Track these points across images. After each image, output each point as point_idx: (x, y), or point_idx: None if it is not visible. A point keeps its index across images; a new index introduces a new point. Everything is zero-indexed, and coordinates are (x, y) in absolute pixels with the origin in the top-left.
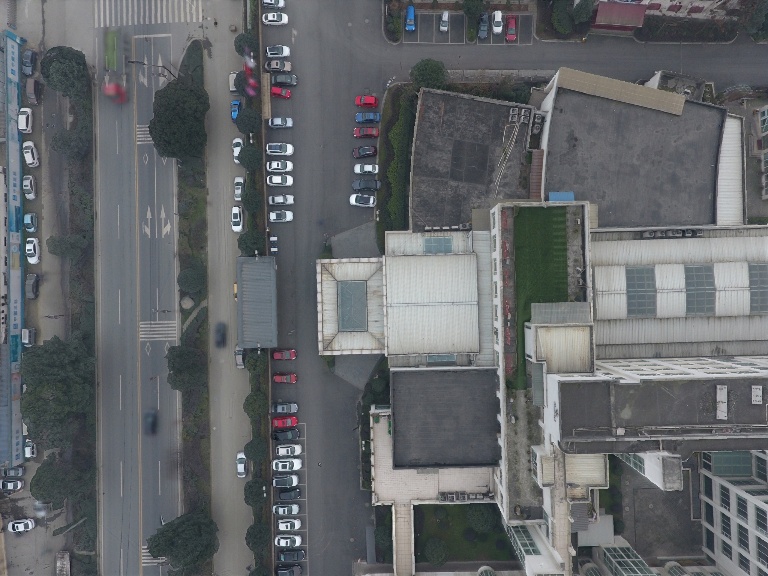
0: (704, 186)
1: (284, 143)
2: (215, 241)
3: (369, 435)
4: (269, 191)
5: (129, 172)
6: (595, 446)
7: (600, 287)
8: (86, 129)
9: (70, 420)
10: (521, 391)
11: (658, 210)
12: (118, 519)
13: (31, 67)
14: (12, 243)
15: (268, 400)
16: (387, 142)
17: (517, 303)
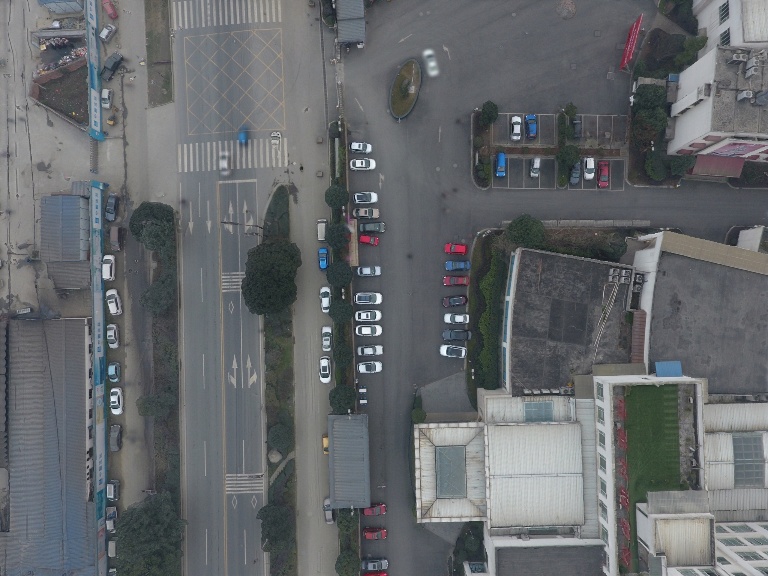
0: None
1: (373, 293)
2: (302, 391)
3: None
4: (357, 340)
5: (214, 321)
6: None
7: (707, 457)
8: (171, 278)
9: None
10: (633, 574)
11: (764, 375)
12: None
13: (114, 213)
14: (97, 397)
15: None
16: (478, 291)
17: (628, 483)
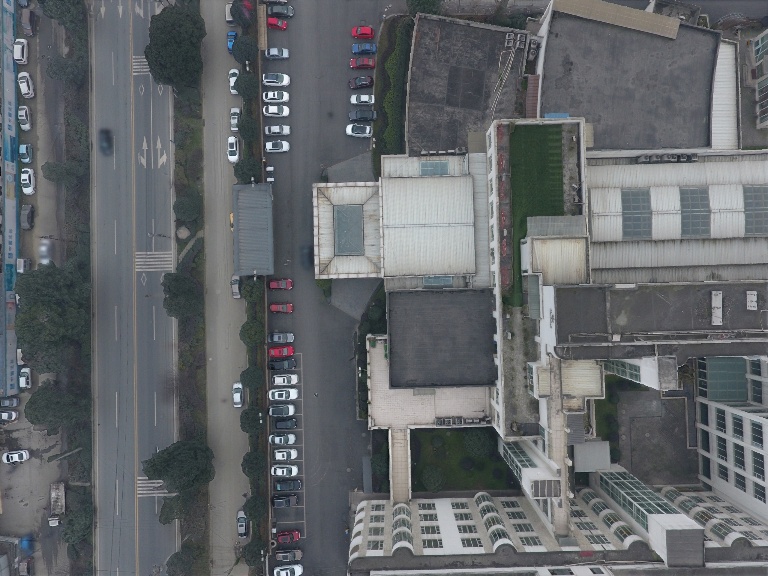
0: (699, 110)
1: (280, 73)
2: (211, 172)
3: (365, 364)
4: (265, 122)
5: (125, 103)
6: (591, 352)
7: (596, 209)
8: (82, 60)
9: (65, 345)
10: (517, 308)
11: (653, 133)
12: (113, 450)
13: None
14: (7, 172)
15: (264, 330)
16: (383, 72)
17: (513, 220)
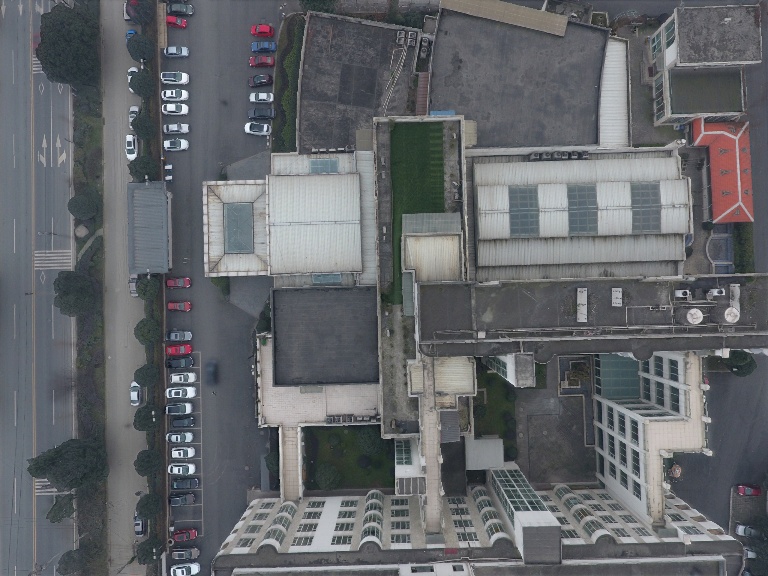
0: (588, 107)
1: (179, 72)
2: (111, 170)
3: None
4: (165, 120)
5: (25, 102)
6: (456, 349)
7: (483, 206)
8: None
9: None
10: (397, 305)
11: (542, 131)
12: (12, 449)
13: None
14: None
15: (162, 328)
16: (282, 71)
17: (394, 218)
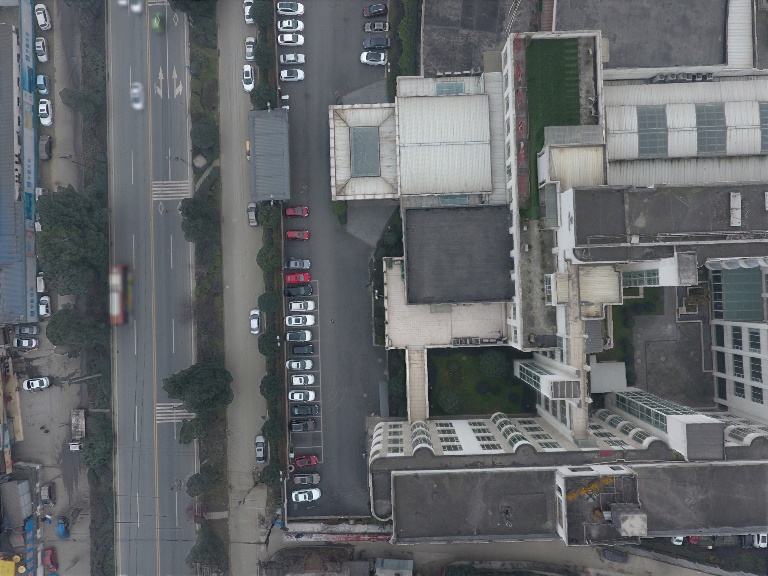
0: (714, 28)
1: (295, 2)
2: (227, 102)
3: (381, 290)
4: (280, 51)
5: (141, 34)
6: (610, 254)
7: (611, 127)
8: None
9: (85, 267)
10: (534, 221)
11: (668, 52)
12: (132, 377)
13: None
14: (25, 102)
15: None
16: (397, 0)
17: (530, 134)
